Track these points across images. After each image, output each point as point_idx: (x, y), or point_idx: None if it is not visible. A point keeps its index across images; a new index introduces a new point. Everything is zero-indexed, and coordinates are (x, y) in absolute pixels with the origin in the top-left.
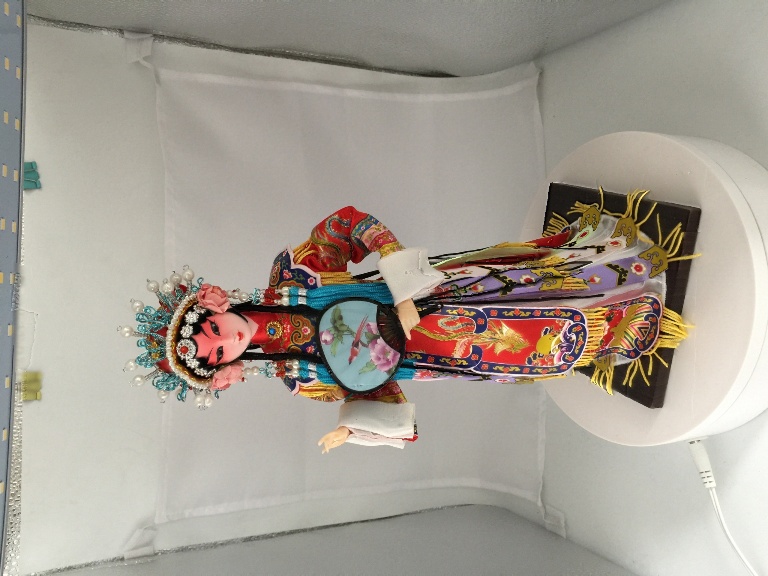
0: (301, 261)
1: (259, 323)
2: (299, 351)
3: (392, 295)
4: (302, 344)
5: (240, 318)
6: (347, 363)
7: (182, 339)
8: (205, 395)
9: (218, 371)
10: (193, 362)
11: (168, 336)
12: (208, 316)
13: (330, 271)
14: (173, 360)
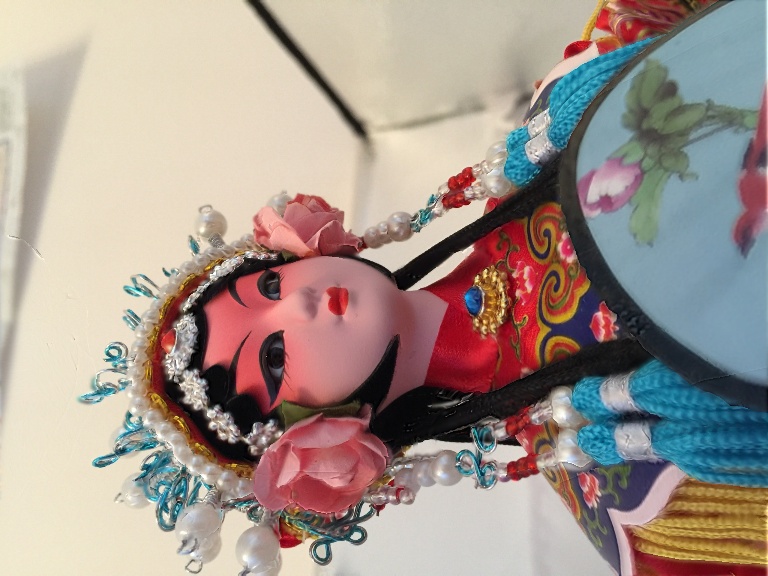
0: None
1: (450, 298)
2: (572, 352)
3: None
4: (572, 314)
5: (368, 267)
6: (727, 254)
7: (182, 318)
8: None
9: None
10: (193, 382)
11: None
12: (274, 265)
13: None
14: (144, 376)
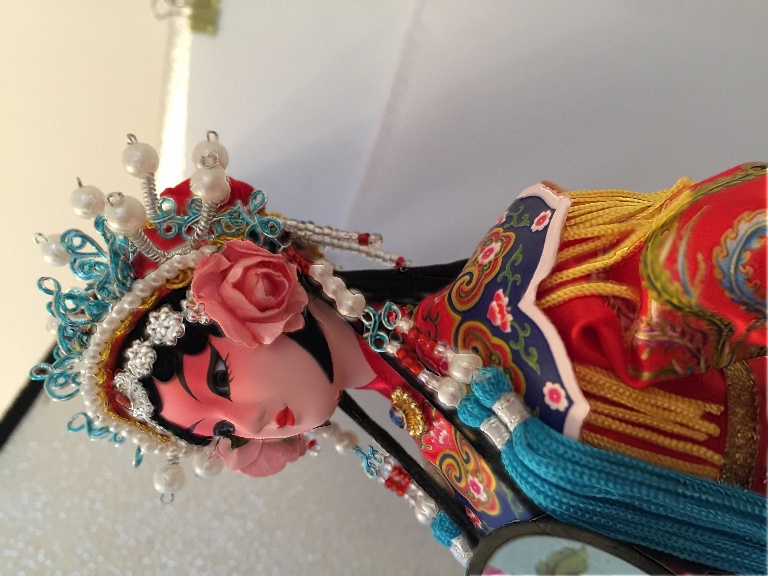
0: (562, 304)
1: (380, 371)
2: (449, 490)
3: None
4: (459, 491)
5: (313, 363)
6: None
7: (127, 369)
8: (205, 451)
9: None
10: (152, 422)
11: (91, 350)
12: (217, 334)
13: None
14: (101, 402)
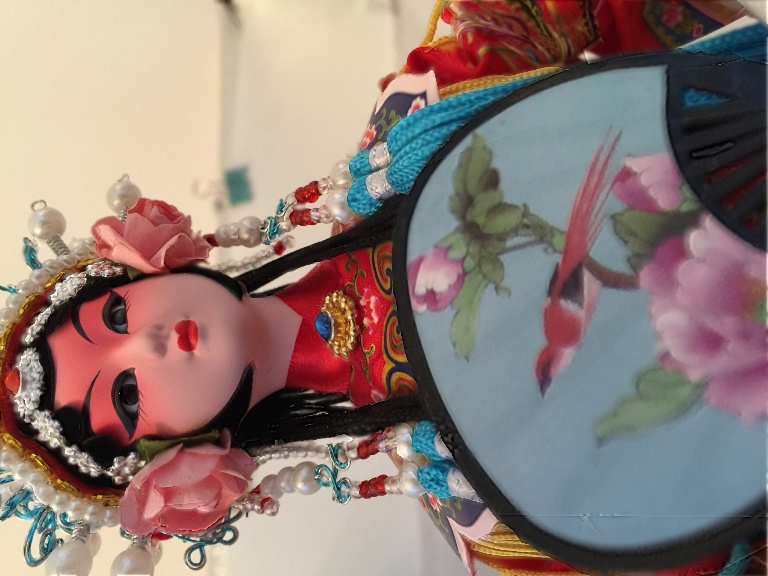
0: None
1: (304, 311)
2: (413, 389)
3: (756, 11)
4: None
5: (219, 287)
6: (529, 388)
7: (25, 350)
8: None
9: (148, 462)
10: (45, 422)
11: None
12: (120, 284)
13: (495, 74)
14: None
